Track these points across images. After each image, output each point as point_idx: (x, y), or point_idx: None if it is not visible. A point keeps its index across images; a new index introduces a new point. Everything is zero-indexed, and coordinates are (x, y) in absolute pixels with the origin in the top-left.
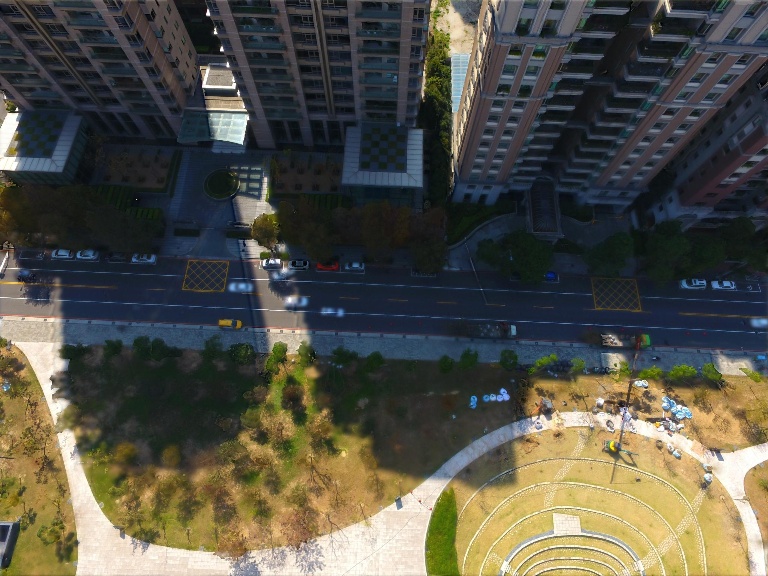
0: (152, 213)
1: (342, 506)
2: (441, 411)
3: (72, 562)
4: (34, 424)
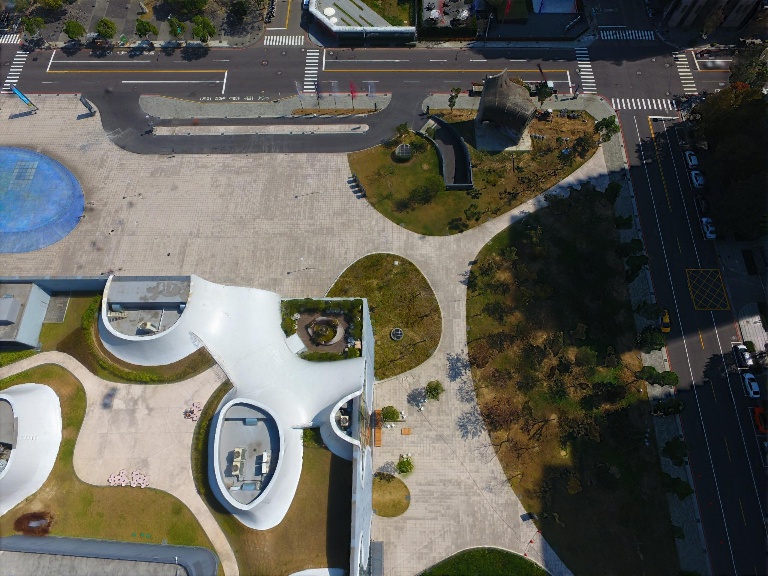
0: (766, 226)
1: (517, 455)
2: (626, 570)
3: (449, 232)
4: None
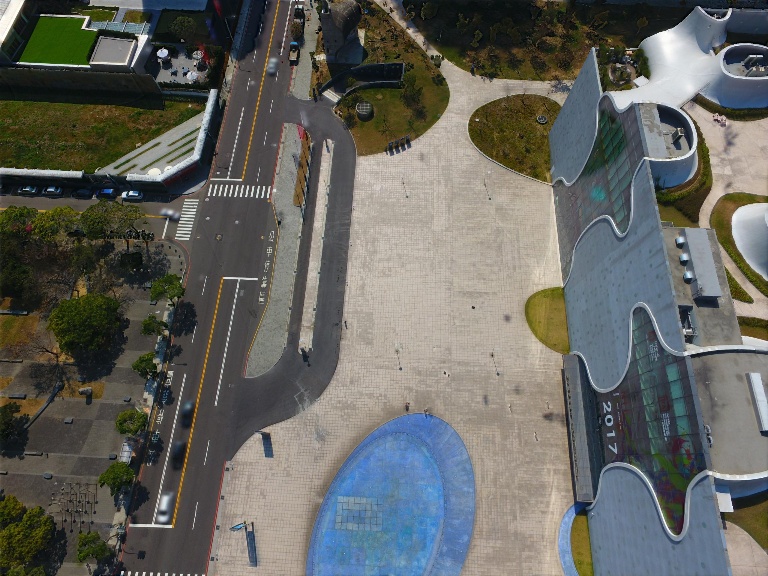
0: None
1: None
2: (669, 25)
3: (445, 86)
4: (392, 28)
